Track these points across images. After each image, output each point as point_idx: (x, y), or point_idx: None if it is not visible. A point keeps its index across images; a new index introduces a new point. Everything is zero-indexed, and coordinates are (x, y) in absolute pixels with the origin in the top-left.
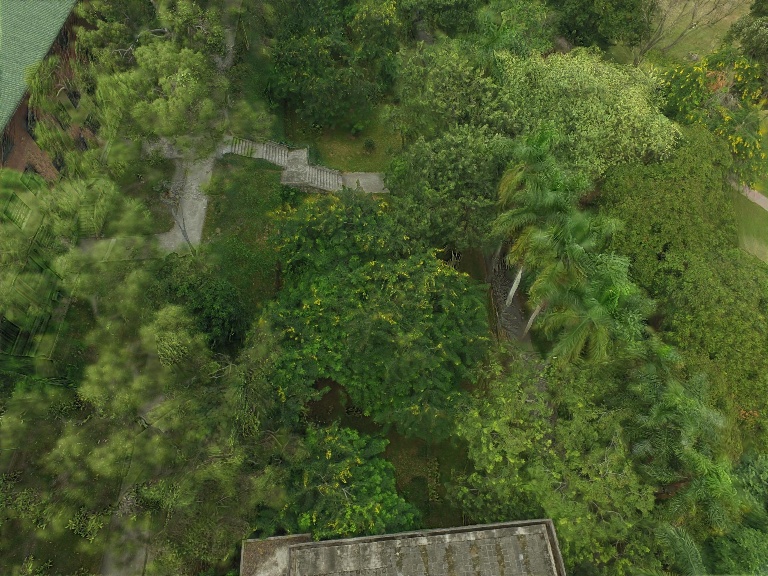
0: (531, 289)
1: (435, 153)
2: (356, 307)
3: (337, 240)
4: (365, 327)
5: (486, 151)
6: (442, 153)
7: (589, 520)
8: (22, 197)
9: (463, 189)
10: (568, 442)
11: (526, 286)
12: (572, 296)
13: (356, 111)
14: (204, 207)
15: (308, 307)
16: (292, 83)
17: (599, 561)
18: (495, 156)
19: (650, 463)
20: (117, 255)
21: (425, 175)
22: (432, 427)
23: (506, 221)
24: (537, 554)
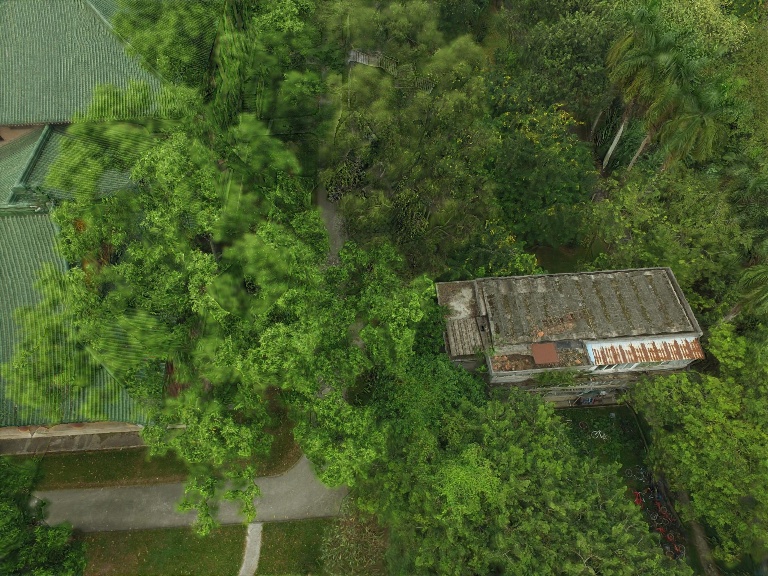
0: (647, 112)
1: (552, 33)
2: (497, 144)
3: (476, 98)
4: (513, 147)
5: (596, 29)
6: (559, 32)
7: (702, 259)
8: (219, 69)
9: (575, 62)
10: (681, 214)
11: (615, 159)
12: (690, 97)
13: (456, 31)
14: (340, 98)
15: (461, 141)
16: (402, 7)
17: (702, 308)
18: (604, 32)
19: (745, 227)
20: (277, 130)
21: (543, 52)
22: (560, 231)
23: (622, 69)
24: (662, 284)
